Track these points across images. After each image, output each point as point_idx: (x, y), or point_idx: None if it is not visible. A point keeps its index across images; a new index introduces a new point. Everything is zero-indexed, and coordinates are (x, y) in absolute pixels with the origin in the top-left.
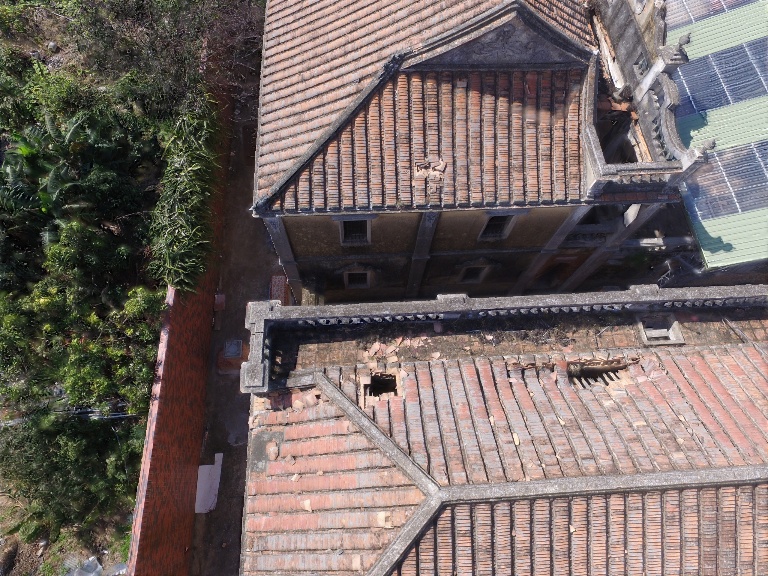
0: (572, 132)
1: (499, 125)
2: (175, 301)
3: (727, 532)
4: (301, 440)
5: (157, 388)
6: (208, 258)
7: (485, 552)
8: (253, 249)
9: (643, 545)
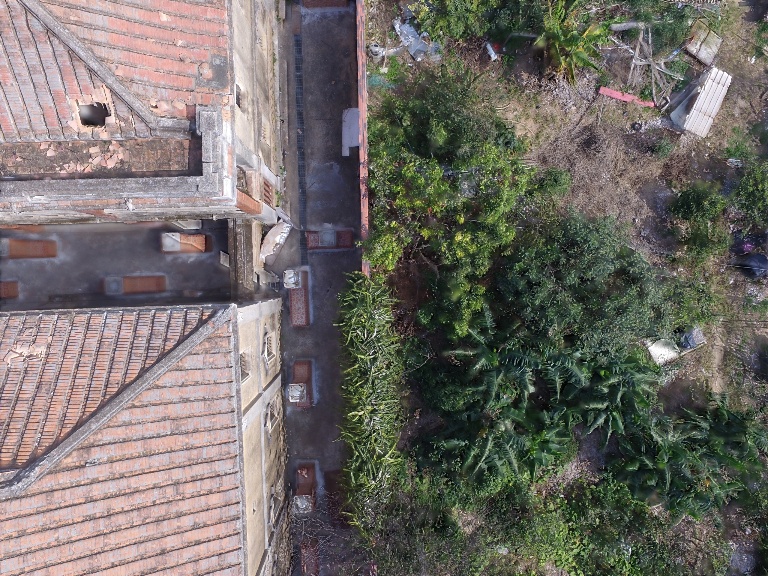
0: None
1: None
2: None
3: None
4: (175, 74)
5: (363, 174)
6: None
7: None
8: (334, 361)
9: None
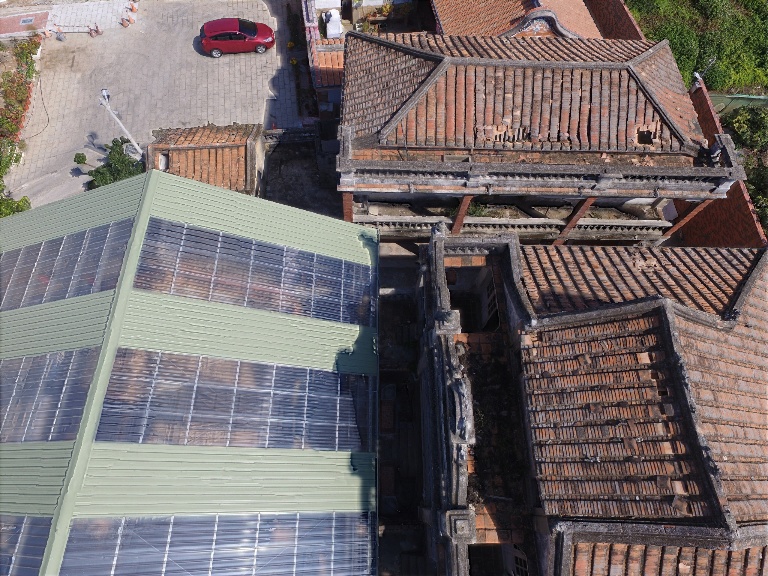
0: (531, 282)
1: None
2: None
3: None
4: None
5: (751, 208)
6: None
7: None
8: None
9: None
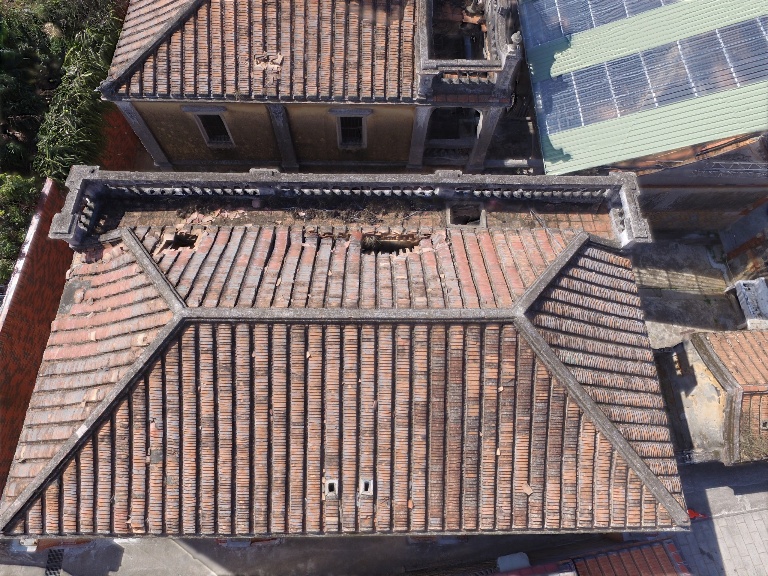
0: (406, 33)
1: (336, 23)
2: (53, 192)
3: (454, 368)
4: (103, 285)
5: (20, 263)
6: (94, 159)
7: (225, 369)
8: None
9: (375, 375)
